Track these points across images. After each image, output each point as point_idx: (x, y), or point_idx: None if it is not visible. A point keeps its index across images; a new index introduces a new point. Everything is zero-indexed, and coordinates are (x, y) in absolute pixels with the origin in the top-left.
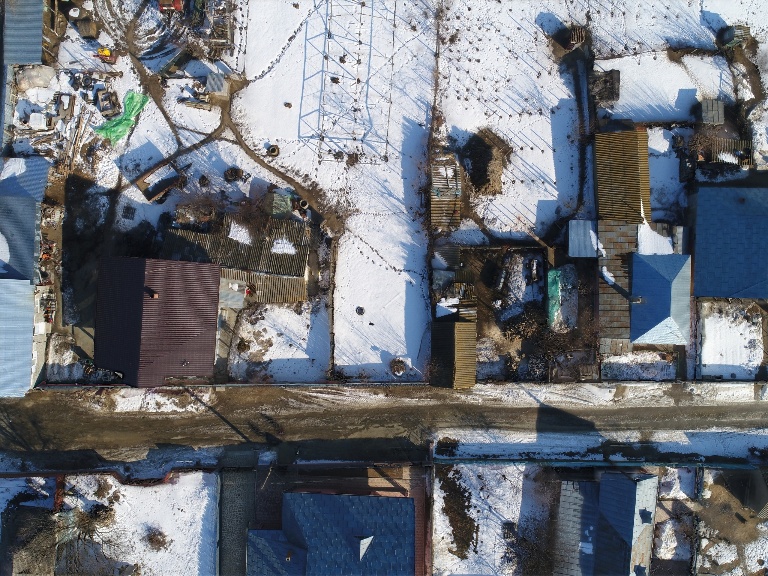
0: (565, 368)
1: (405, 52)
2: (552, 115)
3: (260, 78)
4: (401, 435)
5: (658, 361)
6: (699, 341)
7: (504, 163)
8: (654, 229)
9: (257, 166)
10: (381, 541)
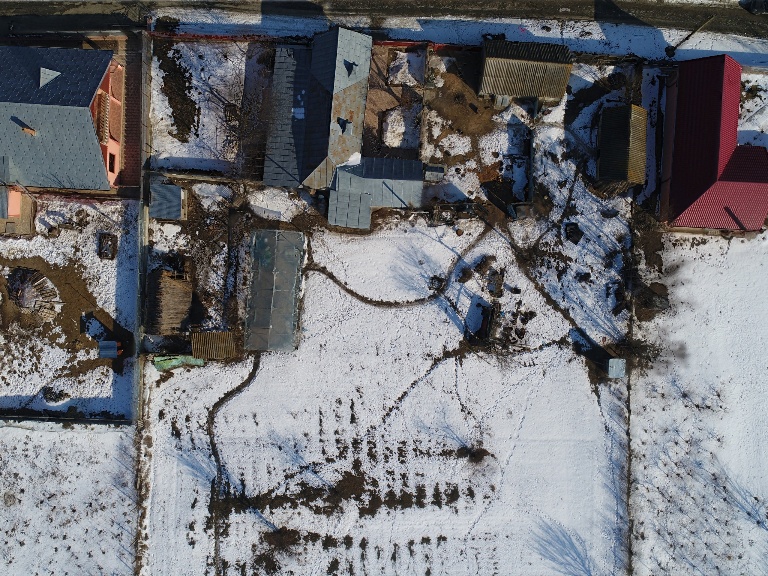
0: None
1: None
2: None
3: None
4: (119, 11)
5: None
6: None
7: None
8: None
9: None
10: (68, 77)
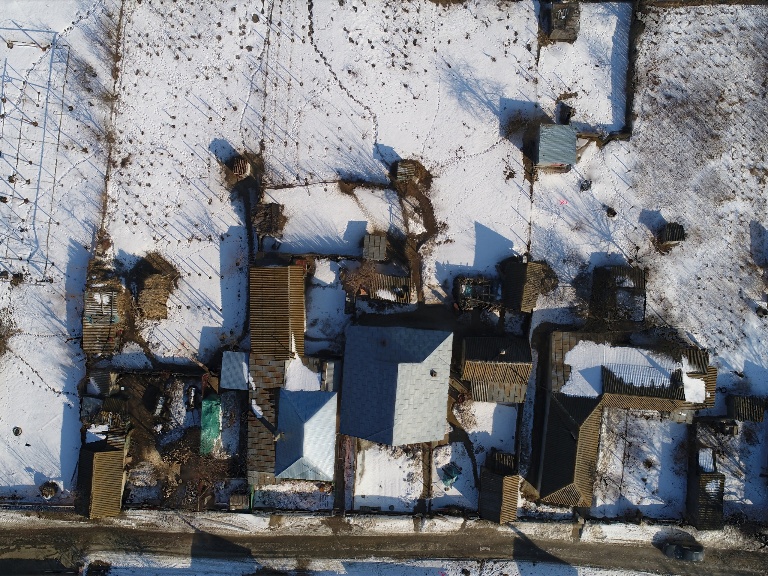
0: (223, 494)
1: (75, 174)
2: (221, 242)
3: None
4: (52, 557)
5: (317, 490)
6: (359, 472)
7: (170, 288)
8: (305, 364)
9: None
10: None
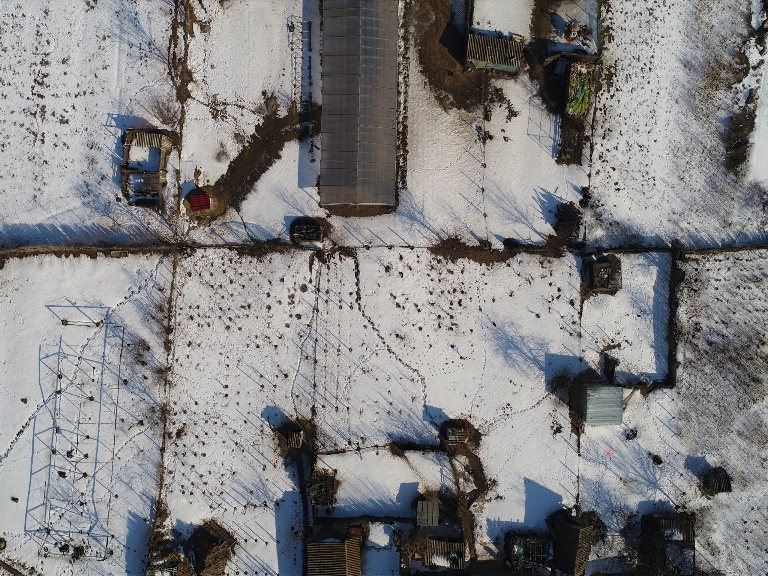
0: None
1: (131, 447)
2: (276, 508)
3: None
4: None
5: None
6: None
7: (228, 555)
8: None
9: None
10: None
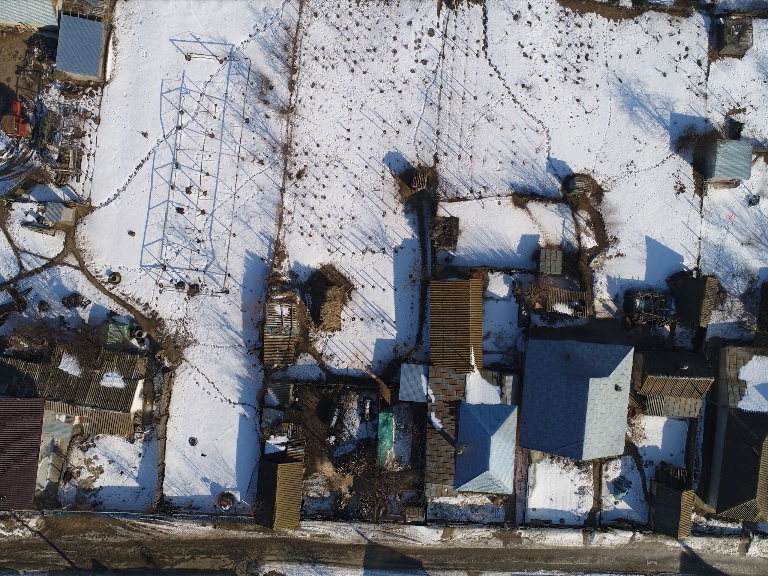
0: (395, 506)
1: (251, 186)
2: (395, 254)
3: (105, 205)
4: (227, 567)
5: (488, 503)
6: None
7: (344, 300)
8: (484, 377)
9: (98, 292)
10: None
